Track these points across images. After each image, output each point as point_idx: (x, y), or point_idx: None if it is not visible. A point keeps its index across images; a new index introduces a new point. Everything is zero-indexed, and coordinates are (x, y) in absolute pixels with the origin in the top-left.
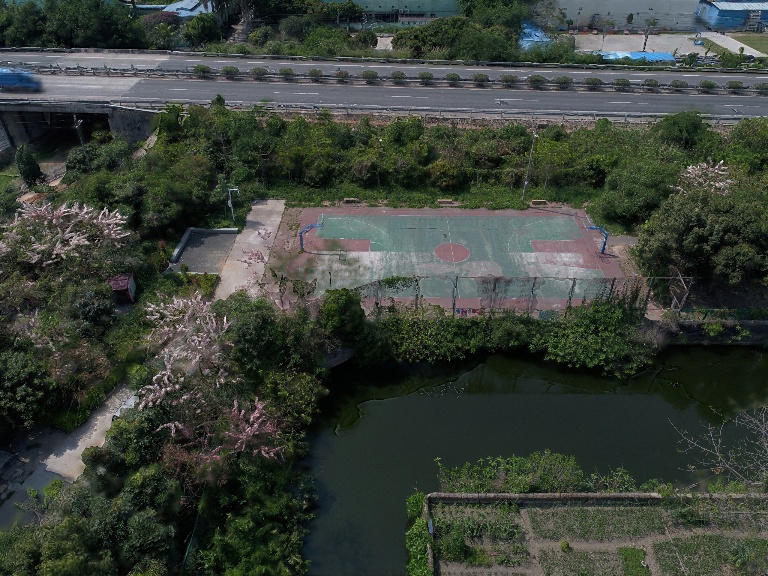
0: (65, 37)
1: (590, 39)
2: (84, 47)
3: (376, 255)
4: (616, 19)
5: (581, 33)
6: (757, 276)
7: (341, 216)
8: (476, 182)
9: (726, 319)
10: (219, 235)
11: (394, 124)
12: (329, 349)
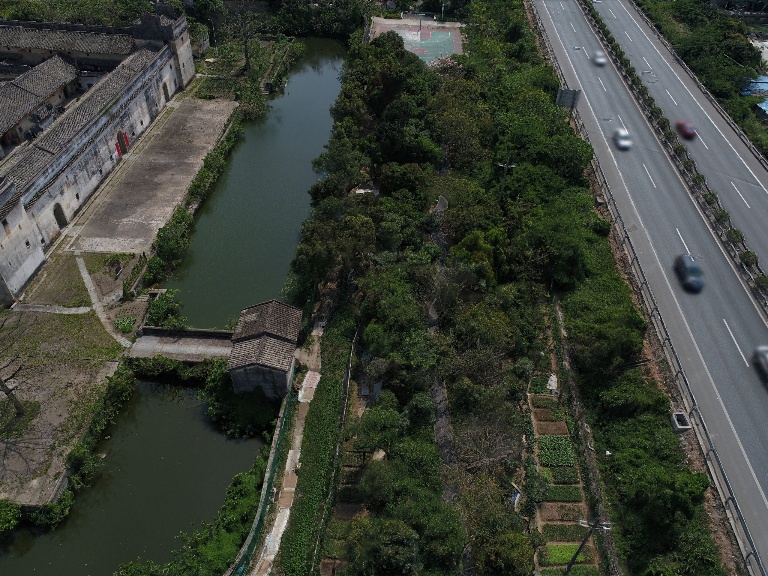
0: None
1: None
2: None
3: (417, 39)
4: None
5: None
6: None
7: (451, 35)
8: None
9: None
10: (433, 18)
11: None
12: None
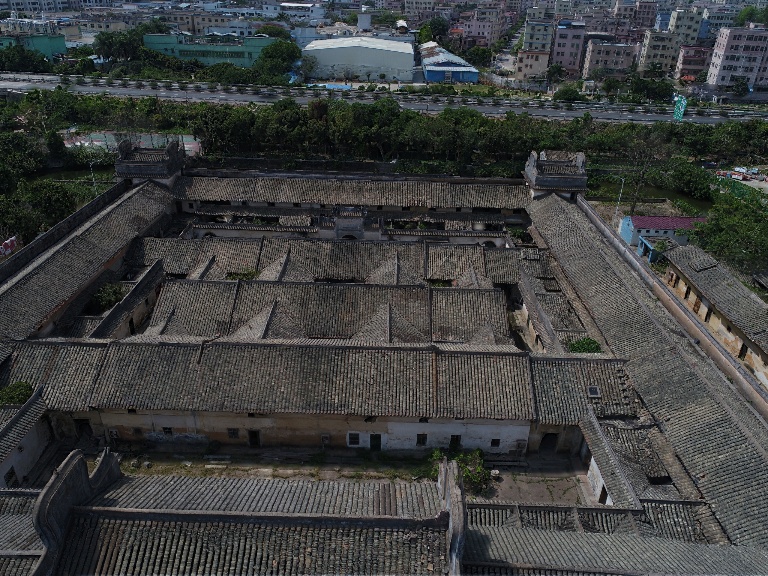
0: (2, 66)
1: (339, 84)
2: (11, 71)
3: None
4: (325, 67)
5: (338, 81)
6: (257, 150)
7: (99, 134)
8: (177, 126)
9: (219, 156)
10: None
11: (141, 99)
12: (43, 150)
